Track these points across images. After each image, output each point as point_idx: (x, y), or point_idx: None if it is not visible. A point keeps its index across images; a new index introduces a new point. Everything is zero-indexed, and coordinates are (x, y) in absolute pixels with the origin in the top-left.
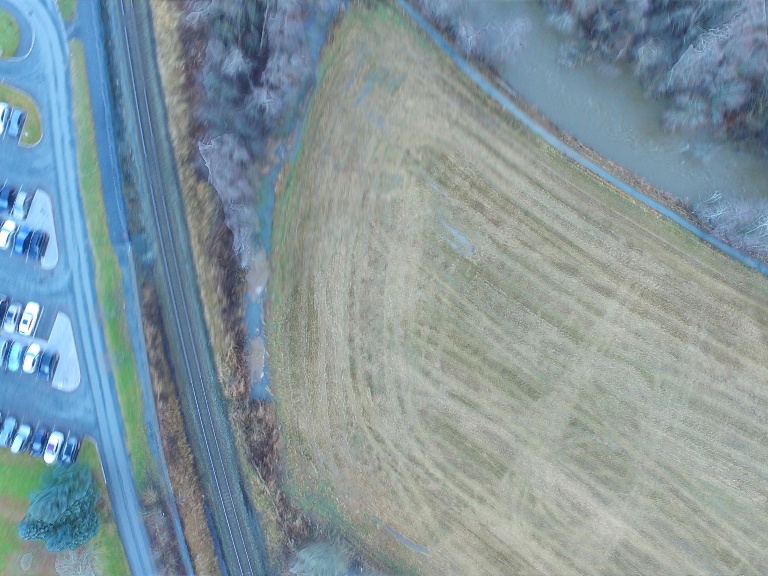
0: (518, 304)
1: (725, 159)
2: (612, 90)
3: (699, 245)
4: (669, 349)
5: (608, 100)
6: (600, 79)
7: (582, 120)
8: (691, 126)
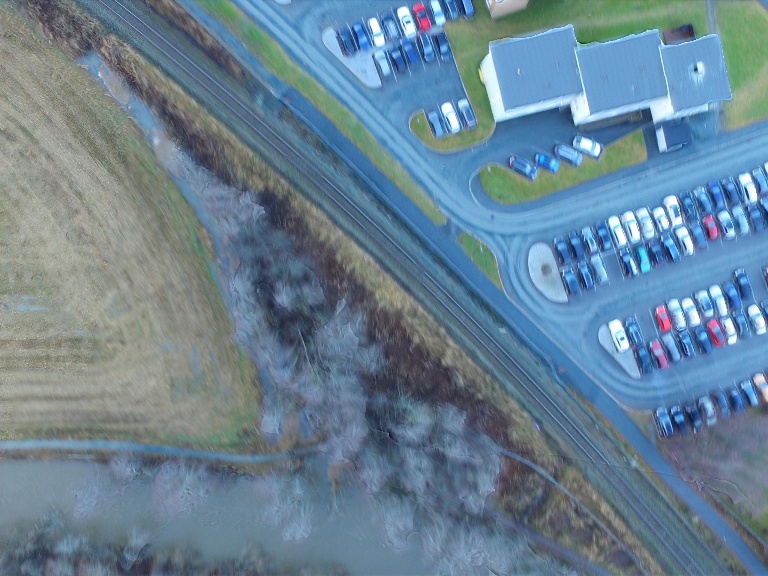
0: None
1: None
2: None
3: None
4: None
5: None
6: (8, 524)
7: None
8: None
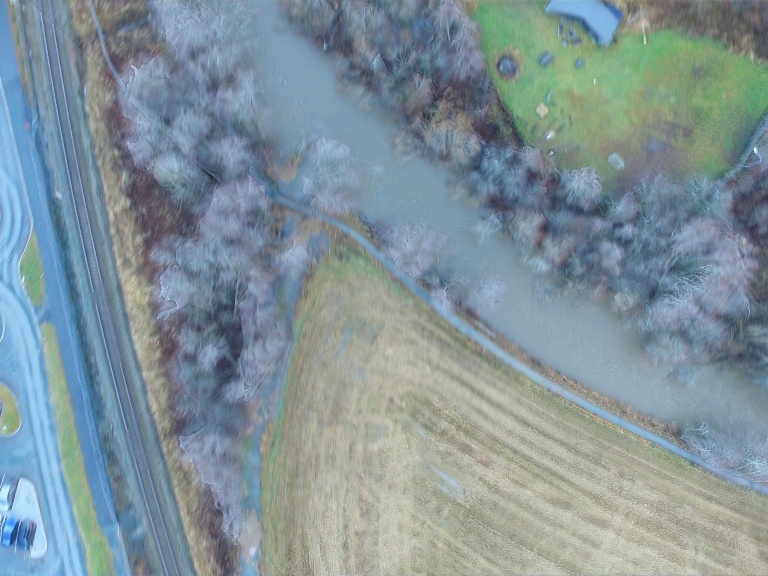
0: (514, 543)
1: (709, 381)
2: (591, 324)
3: (690, 469)
4: (668, 575)
5: (588, 334)
6: (578, 313)
7: (564, 354)
8: (673, 360)
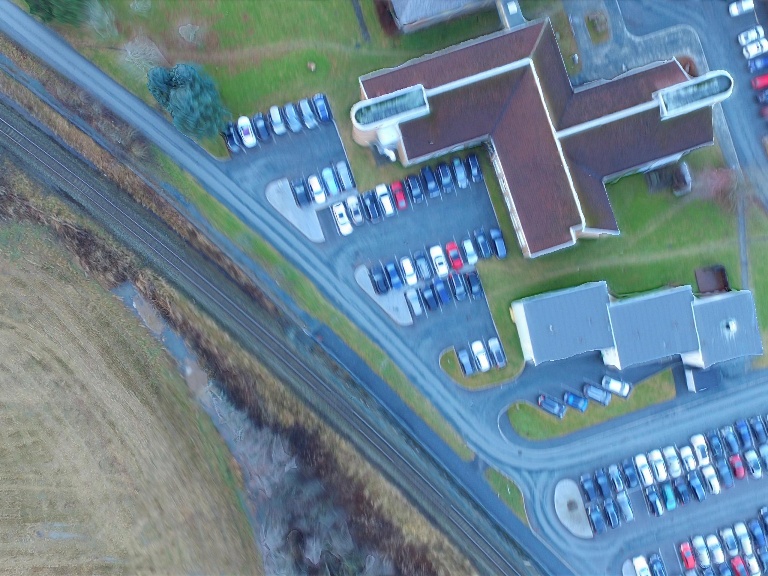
0: None
1: None
2: None
3: None
4: None
5: None
6: None
7: None
8: None
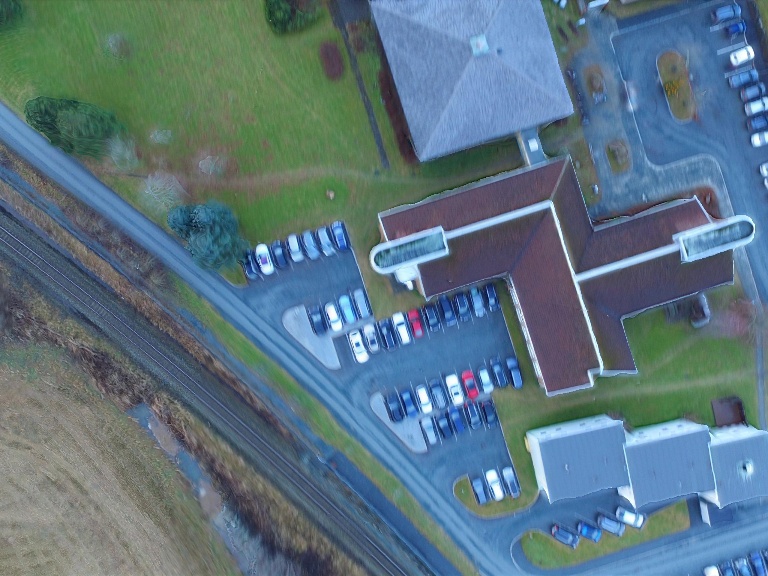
0: None
1: None
2: None
3: None
4: None
5: None
6: None
7: None
8: None
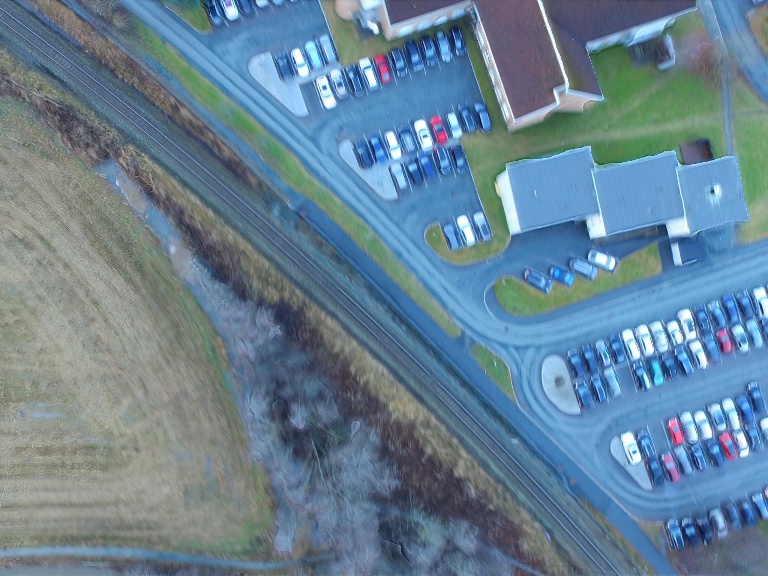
0: None
1: None
2: None
3: None
4: None
5: None
6: None
7: None
8: None
